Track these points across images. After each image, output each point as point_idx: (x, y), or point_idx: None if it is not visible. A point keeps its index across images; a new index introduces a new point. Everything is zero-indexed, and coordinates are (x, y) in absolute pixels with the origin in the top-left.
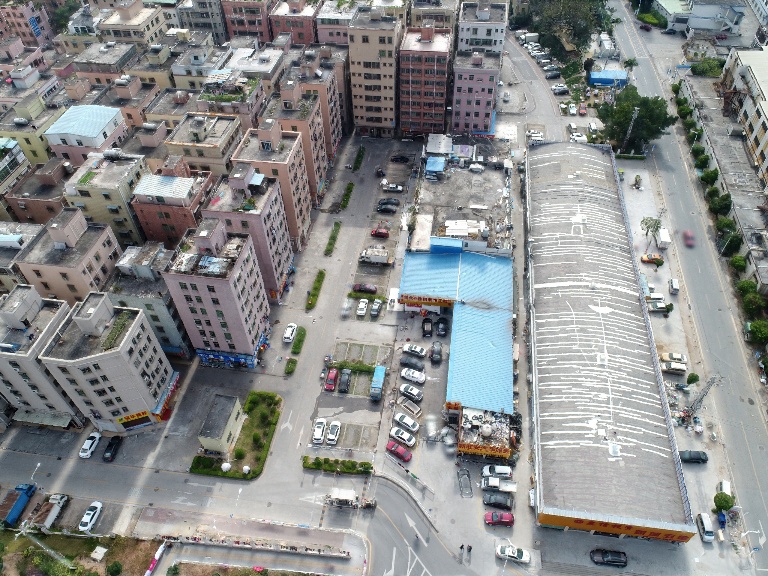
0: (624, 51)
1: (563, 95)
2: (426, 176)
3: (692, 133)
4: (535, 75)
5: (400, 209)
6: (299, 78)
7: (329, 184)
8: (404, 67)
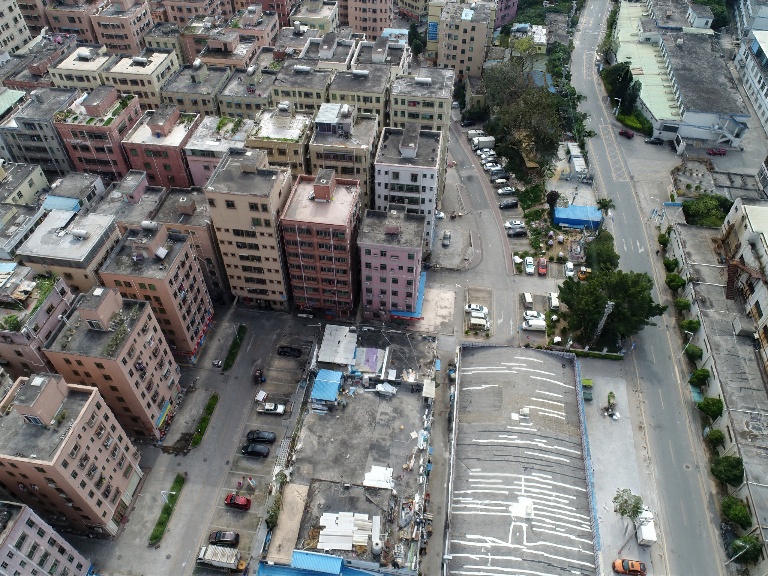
0: (599, 169)
1: (519, 238)
2: (312, 405)
3: (685, 323)
4: (486, 201)
5: (275, 449)
6: (133, 260)
7: (184, 396)
8: (289, 238)
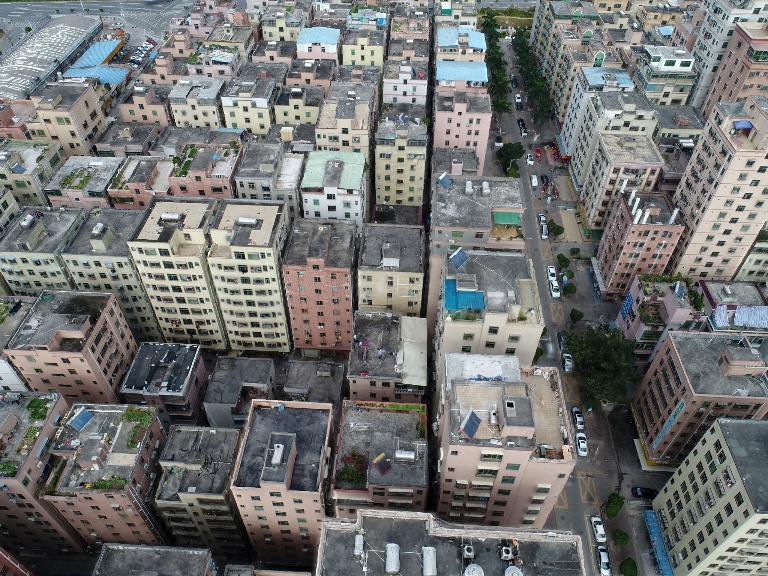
0: None
1: None
2: None
3: None
4: None
5: None
6: (159, 95)
7: None
8: None
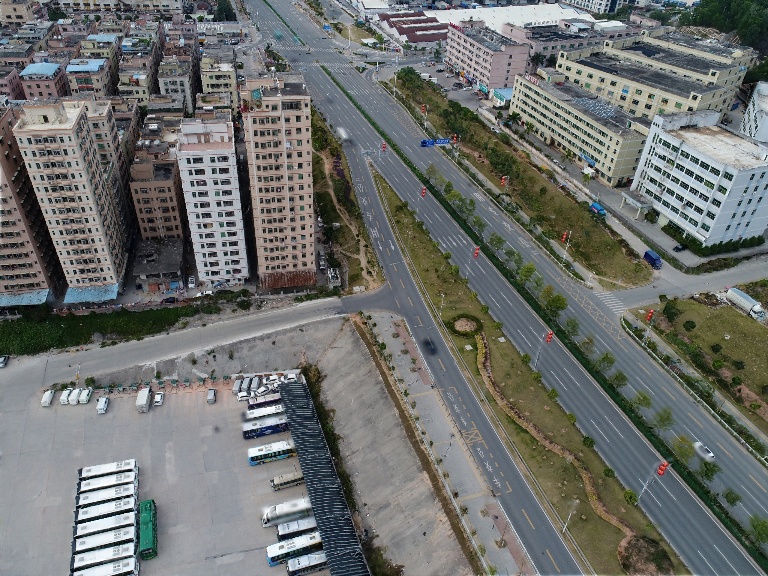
0: None
1: None
2: None
3: None
4: None
5: None
6: None
7: None
8: None
